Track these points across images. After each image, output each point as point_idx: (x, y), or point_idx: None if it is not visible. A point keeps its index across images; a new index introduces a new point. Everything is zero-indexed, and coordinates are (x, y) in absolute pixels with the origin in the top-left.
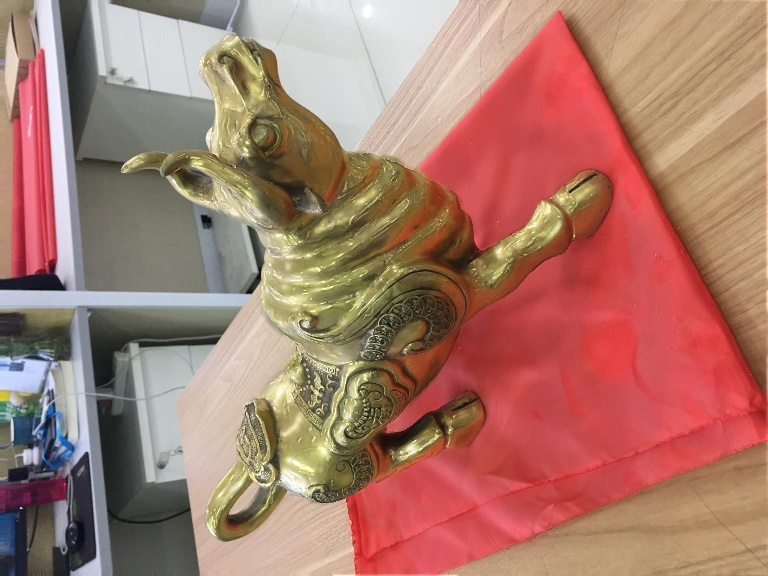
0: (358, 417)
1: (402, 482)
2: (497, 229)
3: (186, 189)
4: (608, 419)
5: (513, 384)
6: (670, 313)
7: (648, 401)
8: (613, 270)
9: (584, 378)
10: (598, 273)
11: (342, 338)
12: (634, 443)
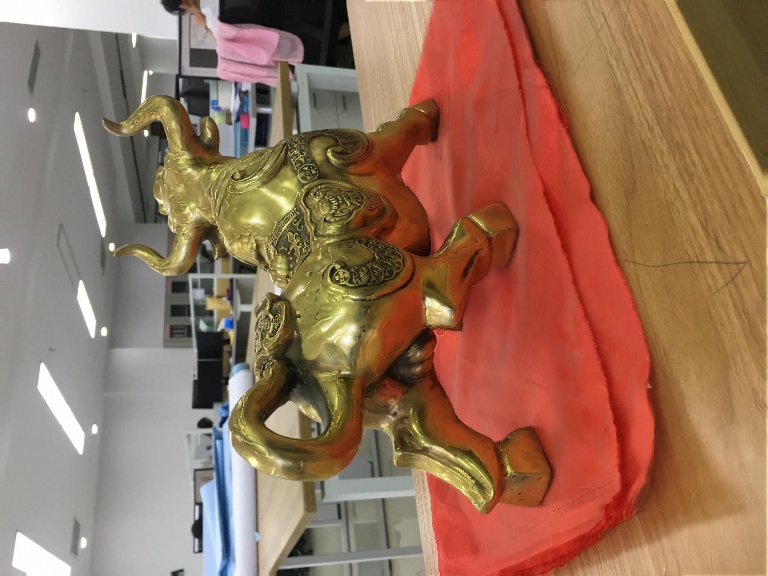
0: (329, 207)
1: (557, 382)
2: (433, 213)
3: (164, 259)
4: (491, 43)
5: (481, 164)
6: (439, 7)
7: (469, 1)
8: (447, 82)
9: (477, 80)
10: (448, 96)
11: (269, 167)
12: (492, 4)
